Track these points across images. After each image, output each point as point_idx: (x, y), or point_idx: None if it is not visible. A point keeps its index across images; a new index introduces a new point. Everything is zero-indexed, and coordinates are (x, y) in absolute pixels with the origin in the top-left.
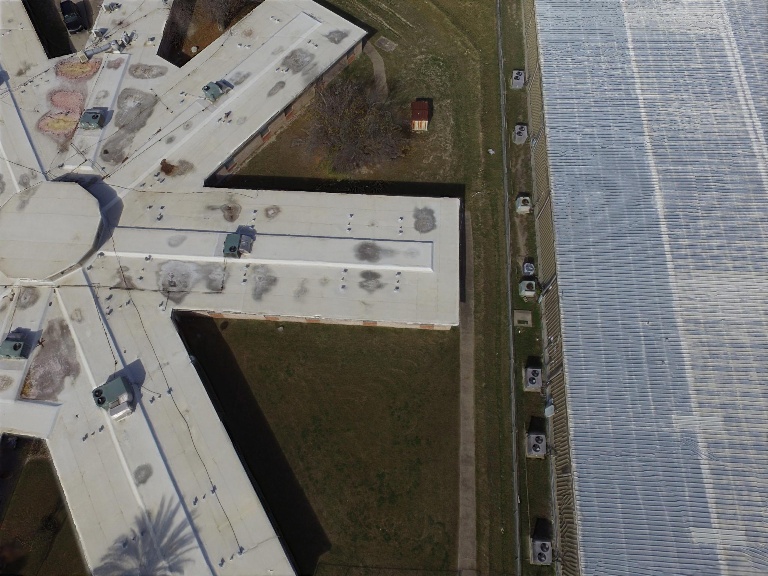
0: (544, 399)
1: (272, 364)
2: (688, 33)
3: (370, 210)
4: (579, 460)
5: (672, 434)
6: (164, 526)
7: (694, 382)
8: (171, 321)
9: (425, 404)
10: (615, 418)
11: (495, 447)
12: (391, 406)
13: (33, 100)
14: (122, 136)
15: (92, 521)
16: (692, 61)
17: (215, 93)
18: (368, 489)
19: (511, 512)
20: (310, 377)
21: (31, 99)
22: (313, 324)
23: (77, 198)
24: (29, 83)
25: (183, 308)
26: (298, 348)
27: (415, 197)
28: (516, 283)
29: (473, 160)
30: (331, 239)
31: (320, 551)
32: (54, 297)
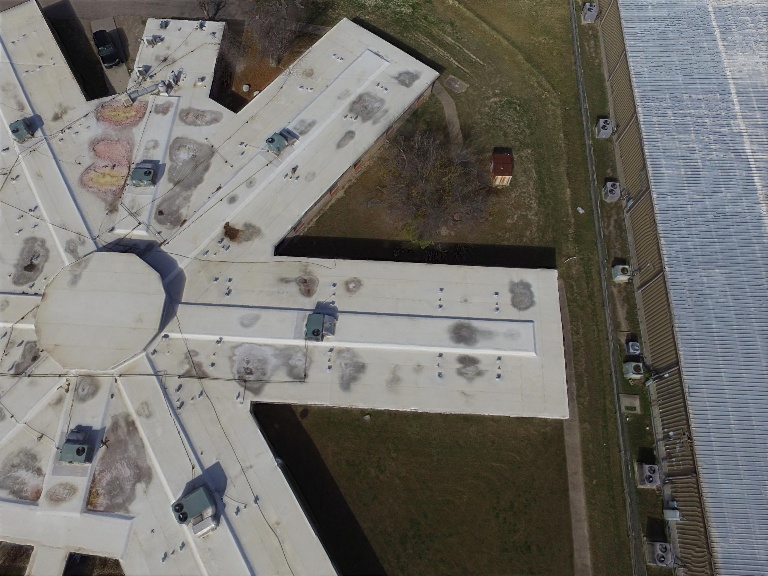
0: (660, 497)
1: (360, 459)
2: None
3: (461, 283)
4: None
5: None
6: None
7: None
8: (251, 416)
9: (532, 504)
10: (759, 536)
11: (611, 553)
12: (495, 507)
13: (73, 150)
14: (178, 194)
15: None
16: None
17: (280, 146)
18: None
19: None
20: (404, 474)
21: (71, 149)
22: (402, 412)
23: (136, 272)
24: (67, 130)
25: (263, 400)
26: (388, 440)
27: (509, 268)
28: (620, 363)
29: (561, 220)
30: (422, 318)
31: None
32: (116, 388)
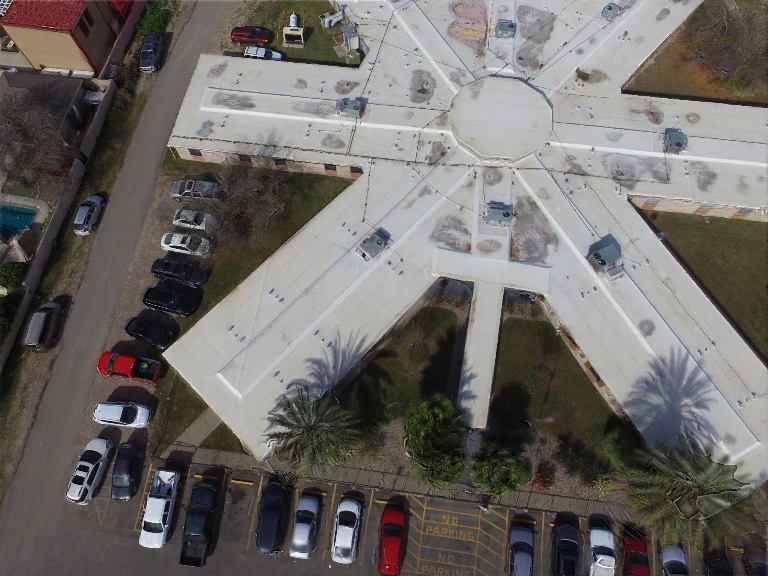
0: None
1: (707, 251)
2: None
3: None
4: None
5: None
6: (680, 371)
7: None
8: (629, 204)
9: None
10: None
11: None
12: None
13: (437, 10)
14: (532, 46)
15: (609, 364)
16: None
17: (615, 13)
18: None
19: None
20: (746, 264)
21: (435, 9)
22: (737, 220)
23: (524, 92)
24: None
25: (637, 194)
26: (728, 239)
27: None
28: None
29: None
30: (758, 144)
31: None
32: (514, 178)
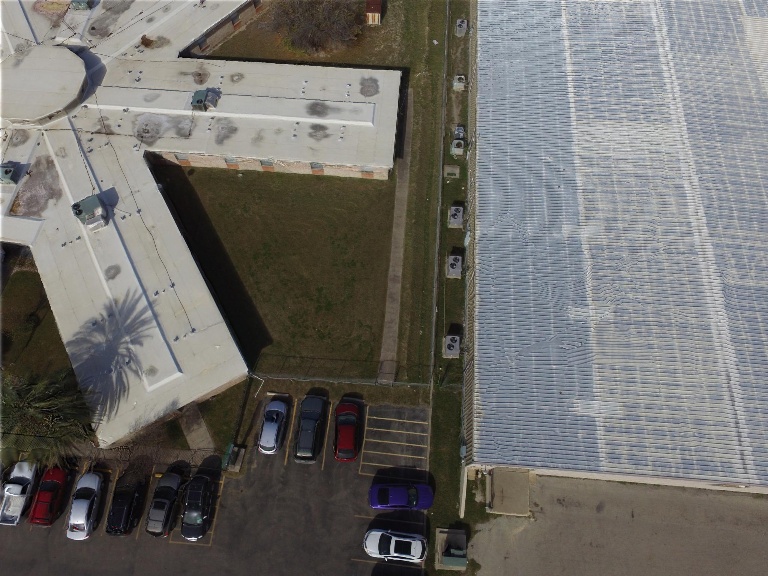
0: (465, 234)
1: (231, 203)
2: None
3: (323, 78)
4: (481, 257)
5: (560, 238)
6: (128, 311)
7: (583, 201)
8: (143, 159)
9: (362, 236)
10: None
11: (420, 269)
12: (332, 237)
13: None
14: (108, 16)
15: (67, 307)
16: None
17: None
18: (308, 299)
19: (429, 318)
20: (263, 213)
21: None
22: (269, 172)
23: (65, 58)
24: None
25: (154, 150)
26: (254, 191)
27: (363, 69)
28: (448, 144)
29: (419, 49)
30: (287, 99)
31: (263, 345)
32: (42, 139)
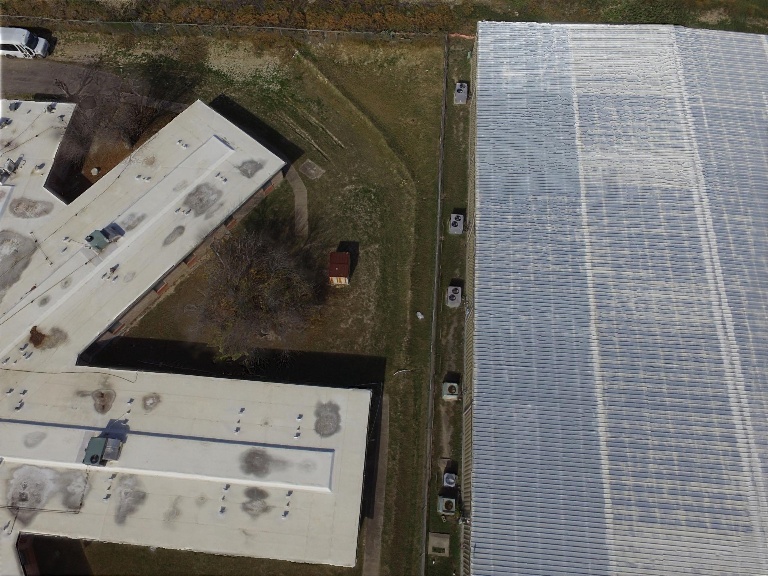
0: None
1: None
2: (652, 187)
3: (265, 403)
4: None
5: None
6: None
7: None
8: (16, 549)
9: None
10: None
11: None
12: None
13: None
14: None
15: None
16: (654, 226)
17: (100, 244)
18: None
19: None
20: None
21: None
22: None
23: None
24: None
25: (32, 531)
26: (171, 575)
27: (319, 387)
28: (434, 496)
29: (398, 325)
30: (214, 443)
31: None
32: None
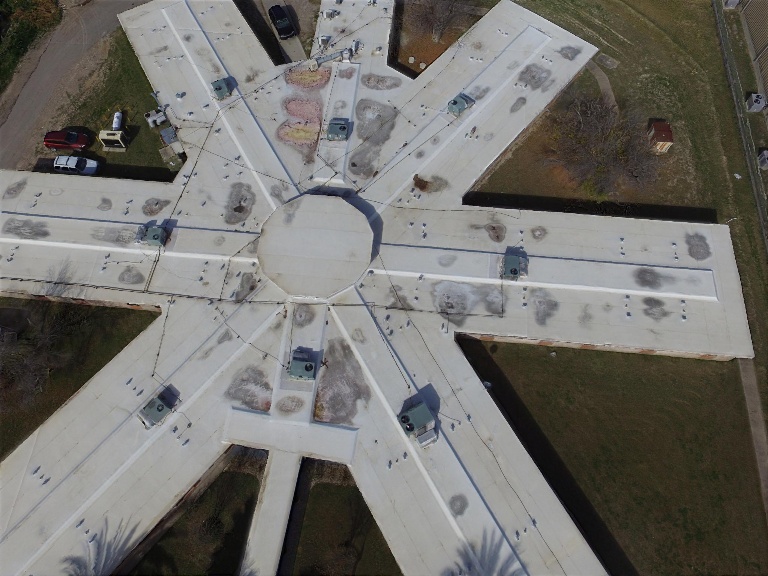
0: None
1: (550, 391)
2: None
3: (640, 235)
4: None
5: None
6: (491, 561)
7: None
8: (456, 344)
9: (716, 438)
10: None
11: None
12: (681, 439)
13: (267, 108)
14: (368, 149)
15: (412, 553)
16: None
17: (461, 108)
18: (672, 525)
19: None
20: (592, 406)
21: (265, 107)
22: (586, 350)
23: (345, 213)
24: (260, 90)
25: (466, 331)
26: (575, 375)
27: (684, 222)
28: None
29: (720, 184)
30: (607, 264)
31: None
32: (329, 315)
